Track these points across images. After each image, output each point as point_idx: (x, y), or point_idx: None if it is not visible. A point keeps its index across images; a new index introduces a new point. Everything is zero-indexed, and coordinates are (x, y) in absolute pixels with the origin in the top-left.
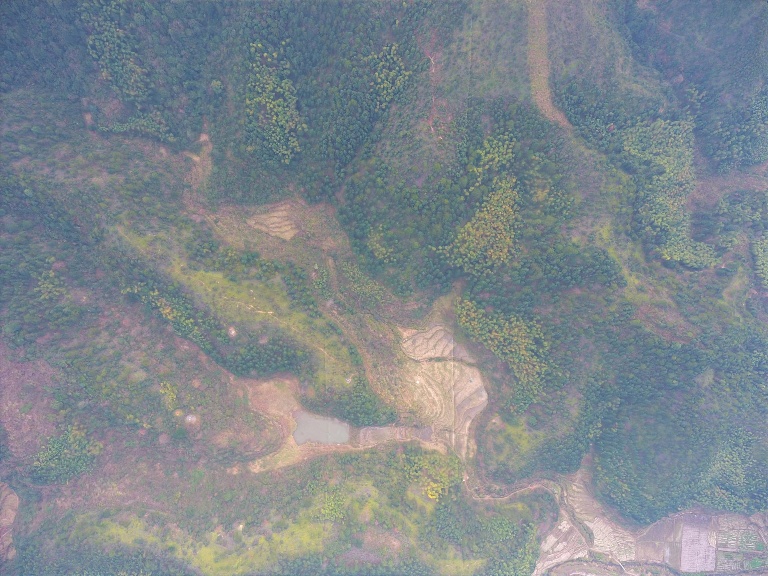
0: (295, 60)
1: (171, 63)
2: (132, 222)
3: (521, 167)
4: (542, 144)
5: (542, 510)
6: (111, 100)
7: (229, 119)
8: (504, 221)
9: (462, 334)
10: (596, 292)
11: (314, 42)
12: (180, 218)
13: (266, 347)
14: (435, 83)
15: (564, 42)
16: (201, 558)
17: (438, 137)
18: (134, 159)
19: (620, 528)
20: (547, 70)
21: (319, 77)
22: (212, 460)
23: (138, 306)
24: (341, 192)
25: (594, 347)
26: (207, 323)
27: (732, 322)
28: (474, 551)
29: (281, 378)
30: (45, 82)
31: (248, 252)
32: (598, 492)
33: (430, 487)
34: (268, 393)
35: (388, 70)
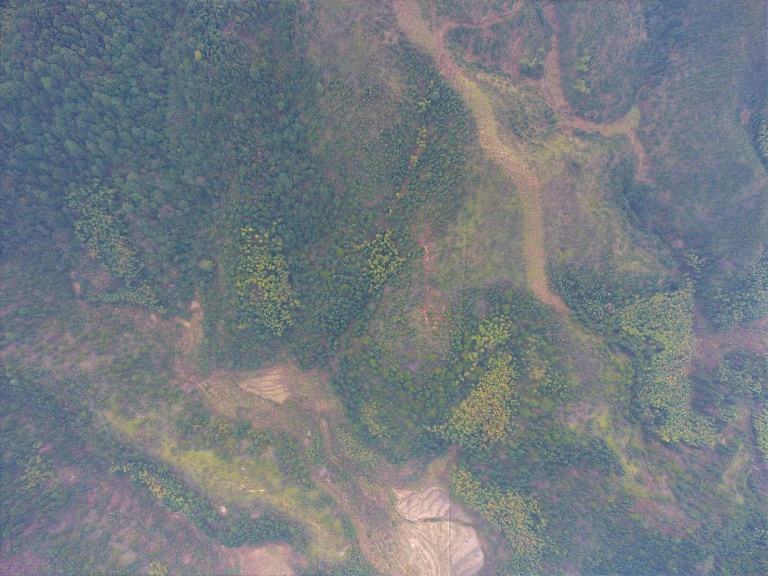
0: (287, 236)
1: (161, 242)
2: (121, 408)
3: (517, 344)
4: (538, 328)
5: None
6: (100, 273)
7: (220, 297)
8: (500, 397)
9: None
10: (594, 476)
11: (306, 224)
12: (170, 393)
13: (258, 521)
14: (429, 273)
15: (561, 235)
16: None
17: (432, 327)
18: (123, 333)
19: None
20: (543, 260)
21: (311, 255)
22: None
23: (128, 478)
24: (334, 361)
25: (592, 529)
26: (197, 504)
27: (733, 517)
28: None
29: (273, 544)
30: (33, 253)
31: (240, 422)
32: None
33: None
34: (260, 560)
35: (381, 254)
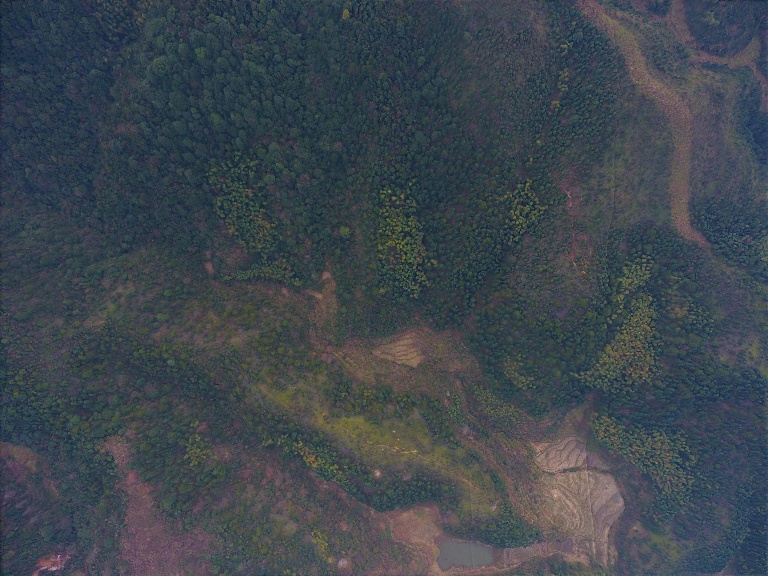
0: (420, 197)
1: (297, 213)
2: (275, 380)
3: (656, 284)
4: (681, 265)
5: None
6: (234, 250)
7: (359, 263)
8: (642, 339)
9: (596, 444)
10: (746, 407)
11: (442, 181)
12: (314, 363)
13: (409, 483)
14: (575, 218)
15: (705, 168)
16: None
17: (581, 272)
18: (262, 308)
19: None
20: (687, 195)
21: (447, 213)
22: None
23: (276, 452)
24: (470, 319)
25: (745, 460)
26: (354, 469)
27: None
28: None
29: (421, 506)
30: (164, 237)
31: (381, 387)
32: None
33: None
34: (409, 522)
35: (521, 205)
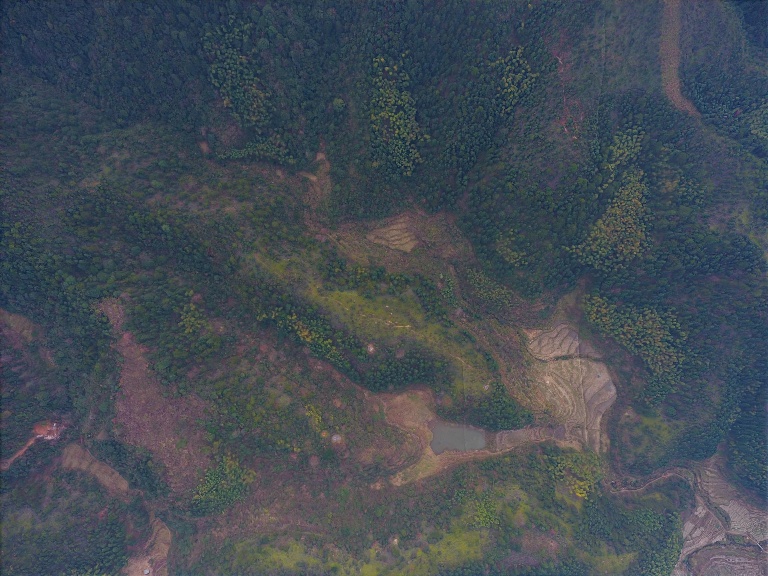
0: (413, 71)
1: (291, 85)
2: (268, 248)
3: (647, 159)
4: (672, 135)
5: (683, 498)
6: (228, 127)
7: (352, 136)
8: (633, 215)
9: (588, 330)
10: (735, 278)
11: (435, 52)
12: (308, 240)
13: (403, 361)
14: (566, 83)
15: (694, 31)
16: (365, 575)
17: (572, 137)
18: (257, 184)
19: (756, 509)
20: (677, 60)
21: (440, 86)
22: (356, 477)
23: (270, 331)
24: (463, 199)
25: (735, 333)
26: (347, 342)
27: None
28: (626, 545)
29: (414, 390)
30: (160, 115)
31: (375, 267)
32: (735, 475)
33: (577, 485)
34: (402, 406)
35: (513, 74)
